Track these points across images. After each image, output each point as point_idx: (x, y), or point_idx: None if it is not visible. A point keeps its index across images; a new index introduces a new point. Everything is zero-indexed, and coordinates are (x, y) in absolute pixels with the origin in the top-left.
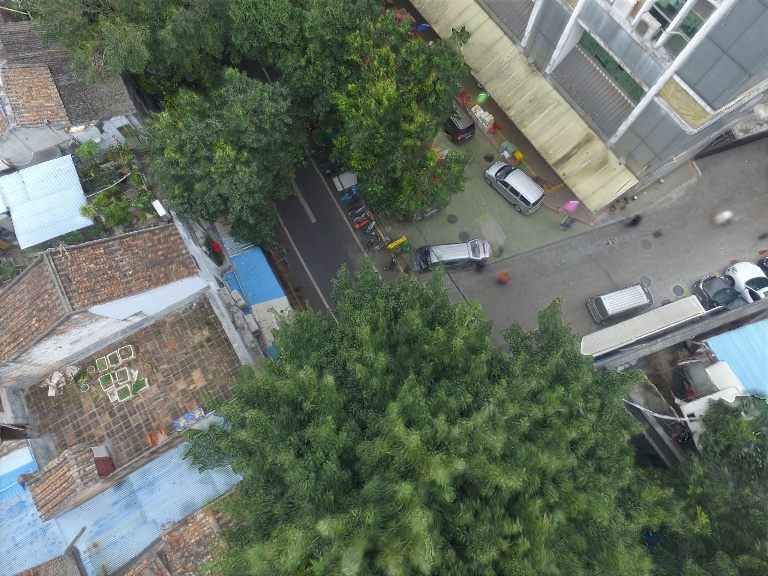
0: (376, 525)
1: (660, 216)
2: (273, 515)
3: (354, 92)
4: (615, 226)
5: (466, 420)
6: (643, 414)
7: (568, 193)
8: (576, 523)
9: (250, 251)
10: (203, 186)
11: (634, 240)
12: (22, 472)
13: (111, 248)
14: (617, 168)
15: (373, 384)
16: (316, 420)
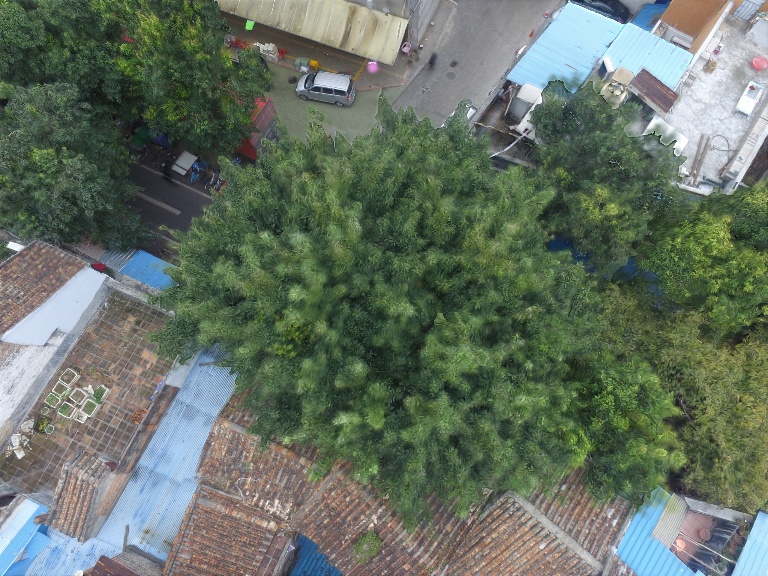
0: (316, 249)
1: (447, 50)
2: (246, 314)
3: (129, 51)
4: (420, 76)
5: (340, 159)
6: (500, 158)
7: (370, 71)
8: (465, 195)
9: (134, 257)
10: (42, 193)
11: (440, 78)
12: None
13: None
14: (387, 20)
15: (271, 205)
16: None
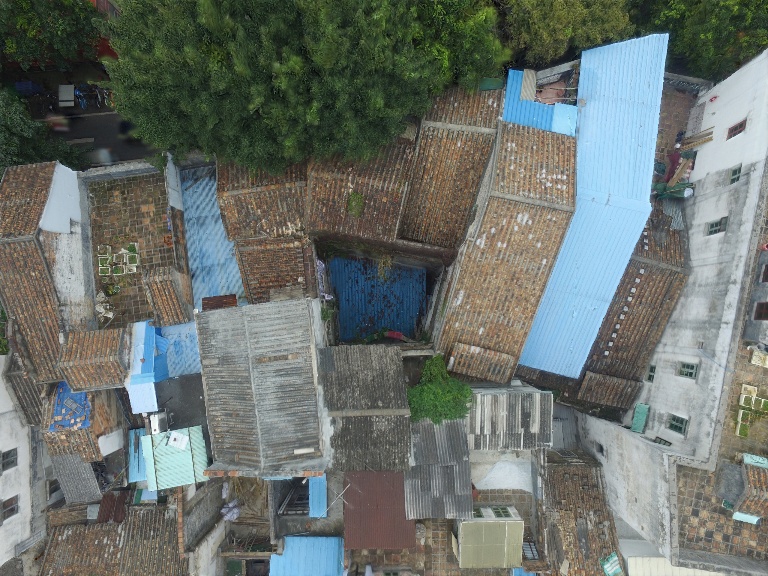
0: None
1: None
2: None
3: None
4: None
5: None
6: None
7: None
8: None
9: None
10: None
11: None
12: (150, 328)
13: (1, 207)
14: None
15: (150, 5)
16: (155, 46)
